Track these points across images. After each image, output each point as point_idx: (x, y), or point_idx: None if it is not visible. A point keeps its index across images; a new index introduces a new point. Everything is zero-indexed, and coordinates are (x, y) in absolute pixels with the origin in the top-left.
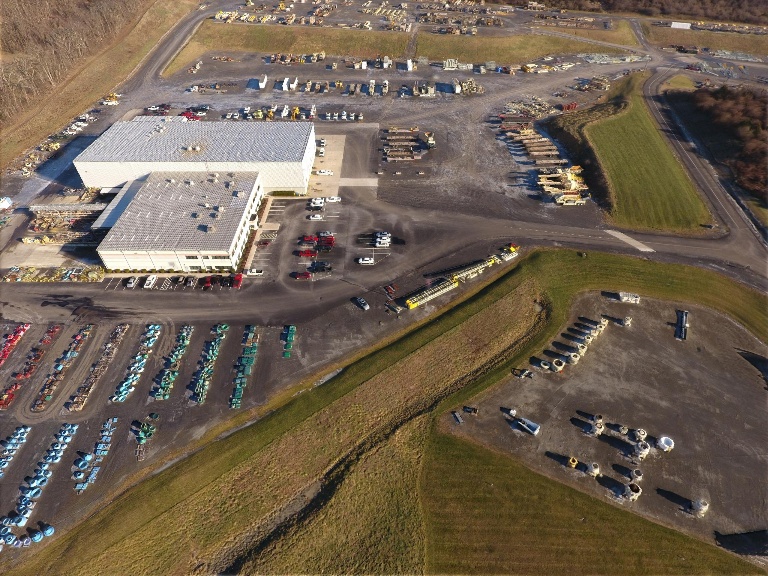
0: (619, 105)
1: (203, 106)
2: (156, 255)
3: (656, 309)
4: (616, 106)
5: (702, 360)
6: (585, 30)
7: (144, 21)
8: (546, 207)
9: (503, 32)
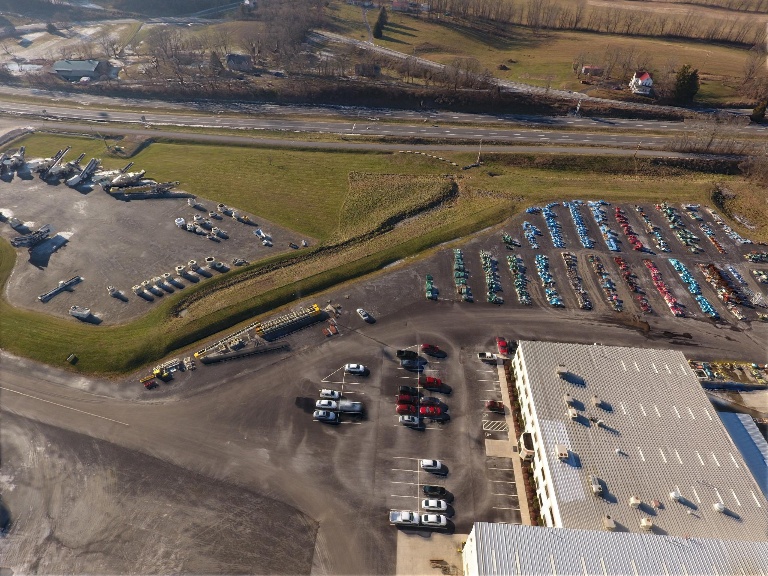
0: None
1: None
2: None
3: (65, 304)
4: None
5: (85, 264)
6: None
7: None
8: (12, 476)
9: None
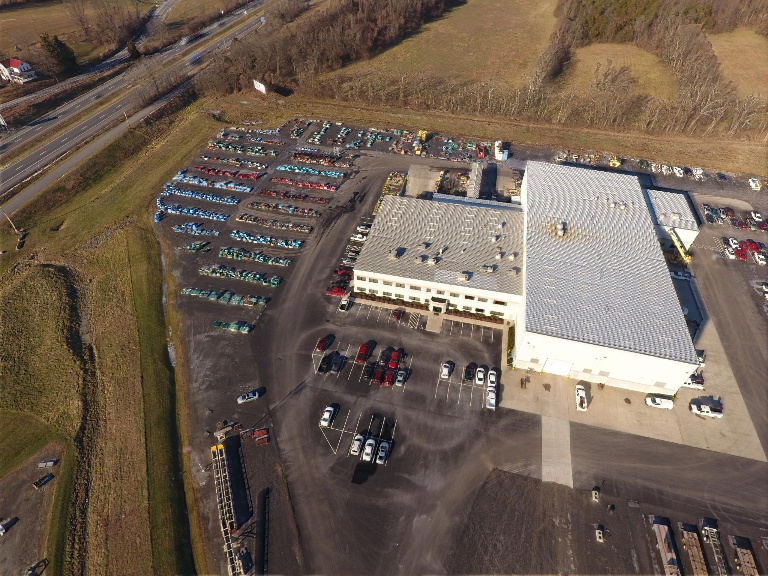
0: None
1: None
2: None
3: None
4: None
5: None
6: None
7: None
8: None
9: None
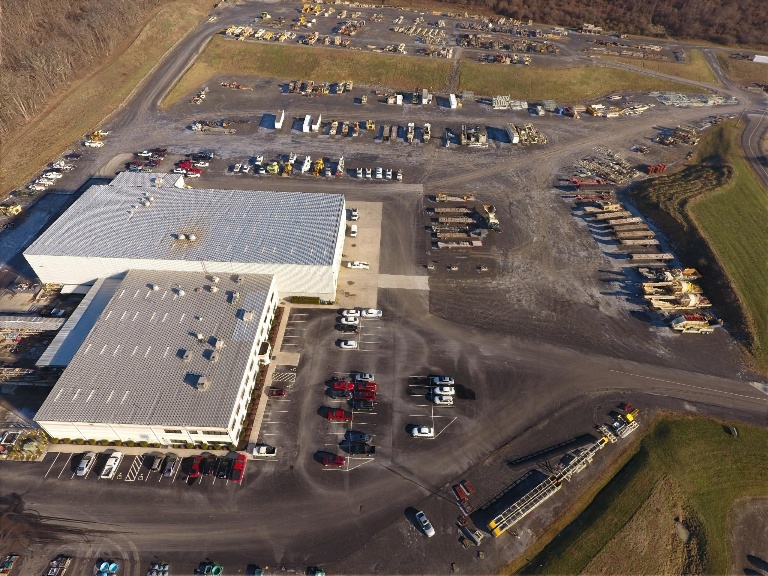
0: (721, 171)
1: (206, 152)
2: (121, 427)
3: None
4: (717, 172)
5: None
6: (654, 62)
7: (144, 36)
8: (659, 335)
9: (560, 62)
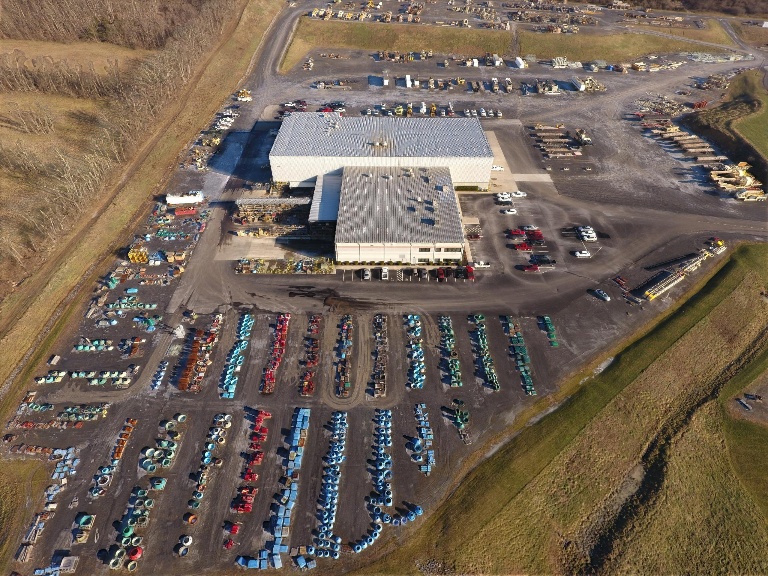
0: (752, 103)
1: (338, 102)
2: (391, 247)
3: None
4: (749, 104)
5: None
6: (680, 29)
7: (245, 18)
8: (728, 203)
9: (601, 31)
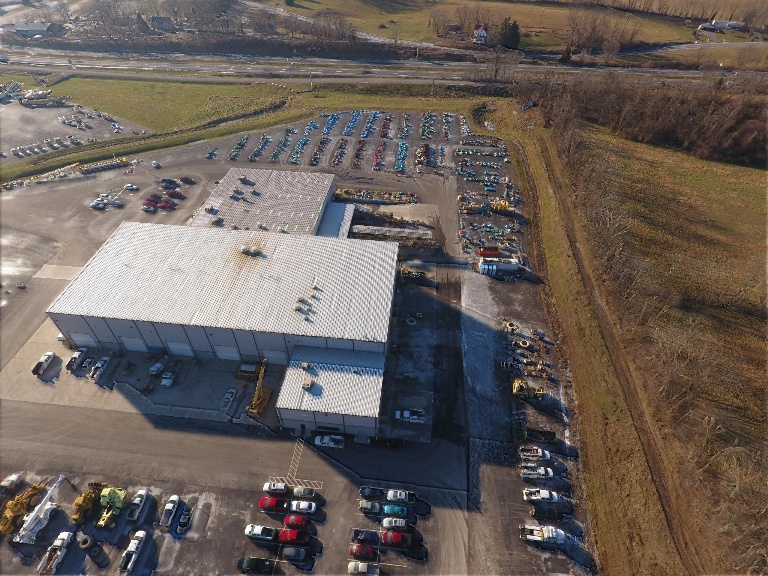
0: None
1: None
2: None
3: None
4: None
5: None
6: None
7: None
8: None
9: None
